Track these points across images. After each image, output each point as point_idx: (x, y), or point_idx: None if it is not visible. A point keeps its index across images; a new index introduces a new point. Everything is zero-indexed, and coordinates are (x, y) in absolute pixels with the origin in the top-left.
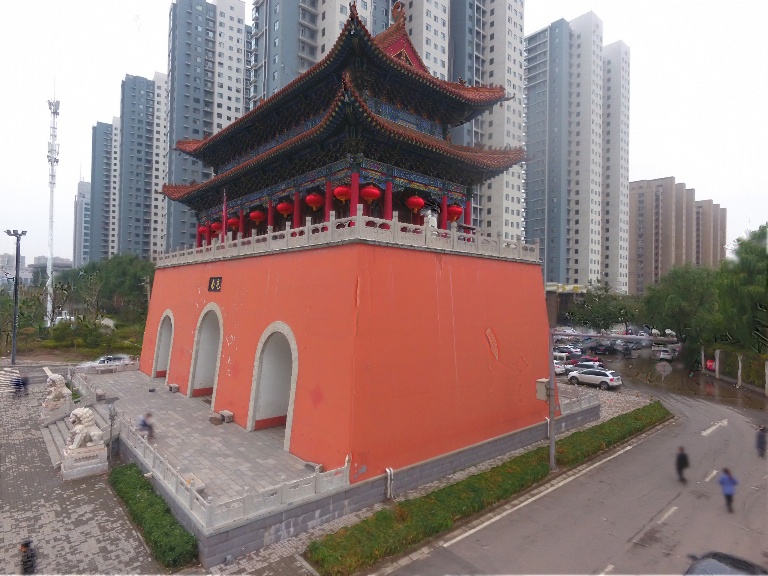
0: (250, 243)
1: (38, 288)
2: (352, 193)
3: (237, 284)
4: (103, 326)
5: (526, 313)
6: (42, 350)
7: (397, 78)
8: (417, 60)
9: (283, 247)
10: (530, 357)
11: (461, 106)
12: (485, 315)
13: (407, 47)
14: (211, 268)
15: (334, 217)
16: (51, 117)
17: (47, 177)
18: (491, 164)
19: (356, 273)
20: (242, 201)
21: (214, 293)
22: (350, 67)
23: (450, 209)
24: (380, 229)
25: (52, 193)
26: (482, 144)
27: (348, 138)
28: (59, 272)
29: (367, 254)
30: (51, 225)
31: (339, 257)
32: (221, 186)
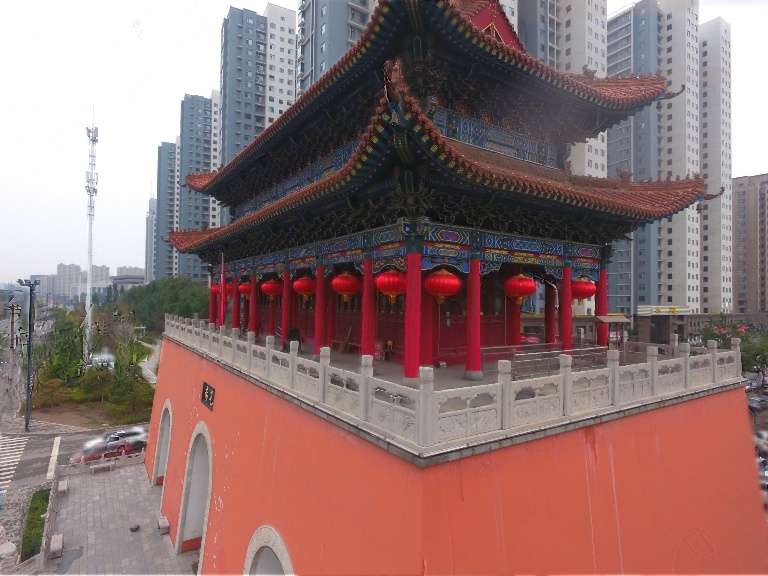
0: (246, 352)
1: (72, 331)
2: (408, 291)
3: (229, 413)
4: (128, 381)
5: (730, 486)
6: (68, 405)
7: (486, 71)
8: (514, 40)
9: (286, 386)
10: (741, 571)
11: (589, 112)
12: (672, 523)
13: (498, 20)
14: (205, 367)
15: (371, 369)
16: (90, 145)
17: (86, 209)
18: (653, 211)
19: (419, 545)
20: (254, 263)
21: (206, 409)
22: (403, 57)
23: (574, 287)
24: (472, 411)
25: (91, 225)
26: (625, 173)
27: (400, 191)
28: (95, 311)
29: (445, 486)
30: (90, 259)
31: (380, 474)
32: (229, 240)
